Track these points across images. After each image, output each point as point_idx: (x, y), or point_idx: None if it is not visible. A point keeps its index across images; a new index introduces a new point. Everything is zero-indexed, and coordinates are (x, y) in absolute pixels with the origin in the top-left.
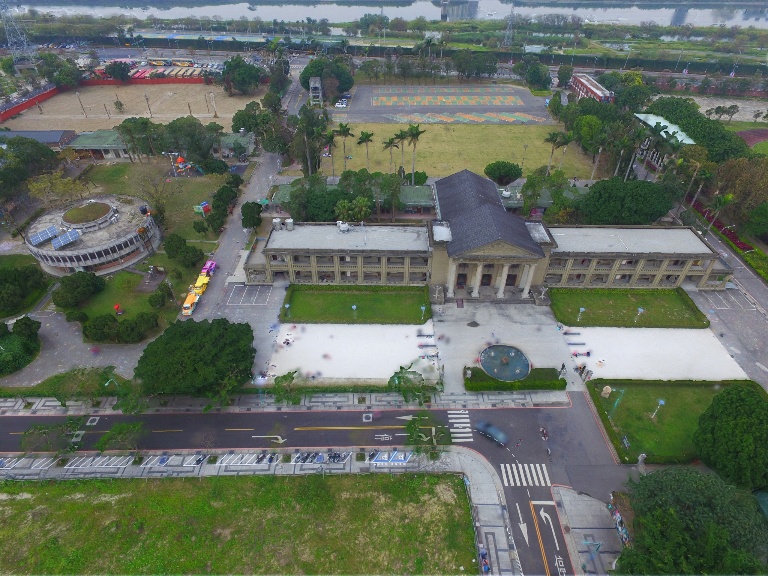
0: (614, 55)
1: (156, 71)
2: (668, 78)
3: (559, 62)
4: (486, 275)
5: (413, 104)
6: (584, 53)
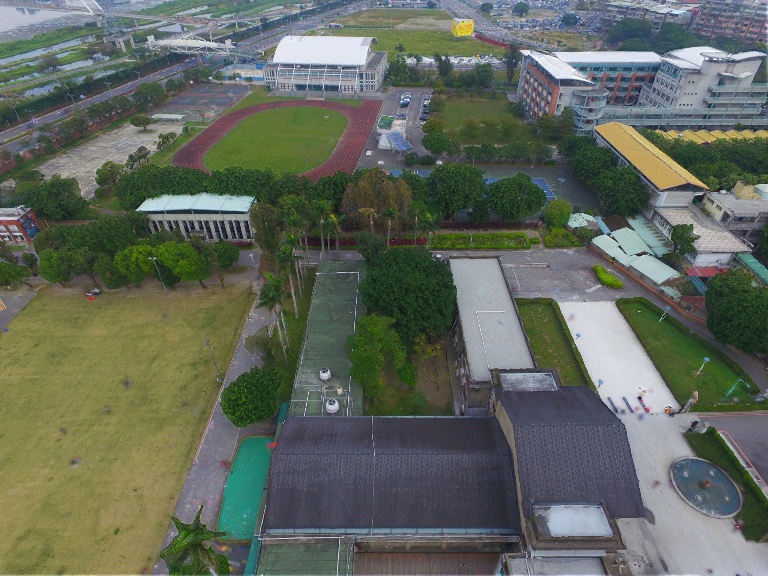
0: None
1: None
2: (1, 155)
3: None
4: None
5: None
6: None
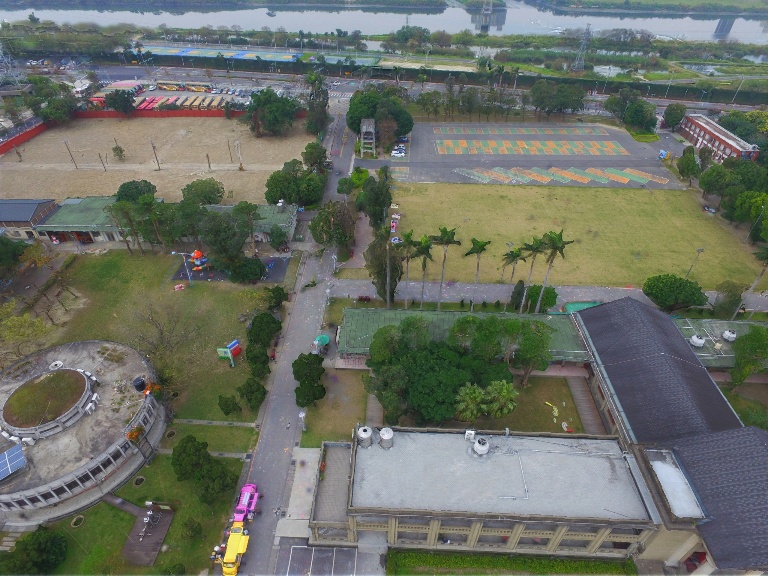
0: (714, 84)
1: (167, 100)
2: None
3: (650, 93)
4: None
5: (489, 153)
6: (669, 78)
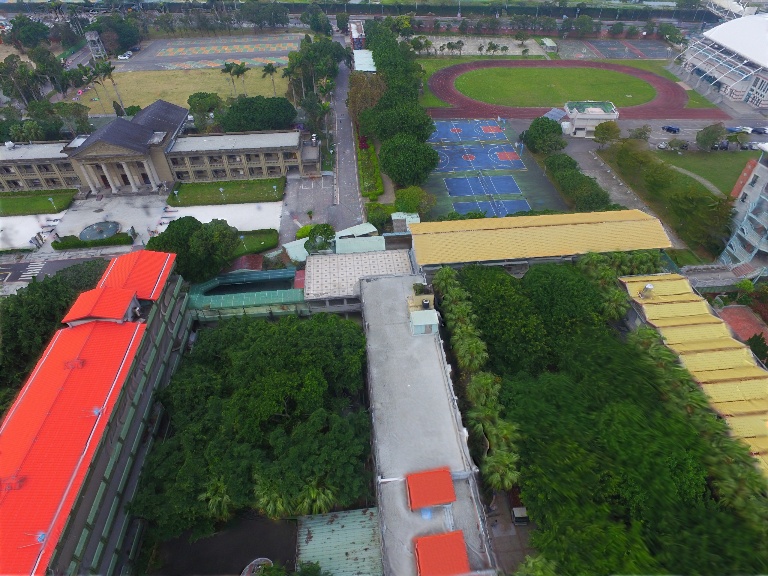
0: (413, 3)
1: None
2: (434, 21)
3: (359, 11)
4: (124, 175)
5: (194, 53)
6: None
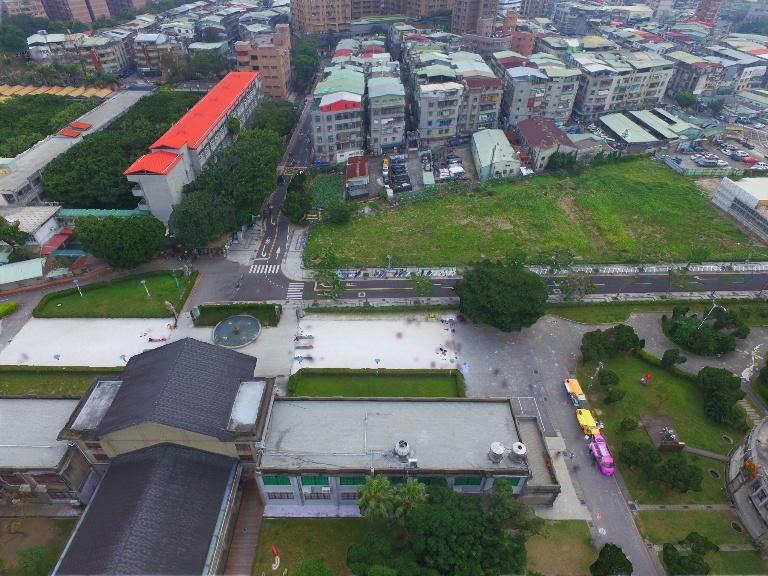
0: None
1: None
2: None
3: None
4: None
5: None
6: None
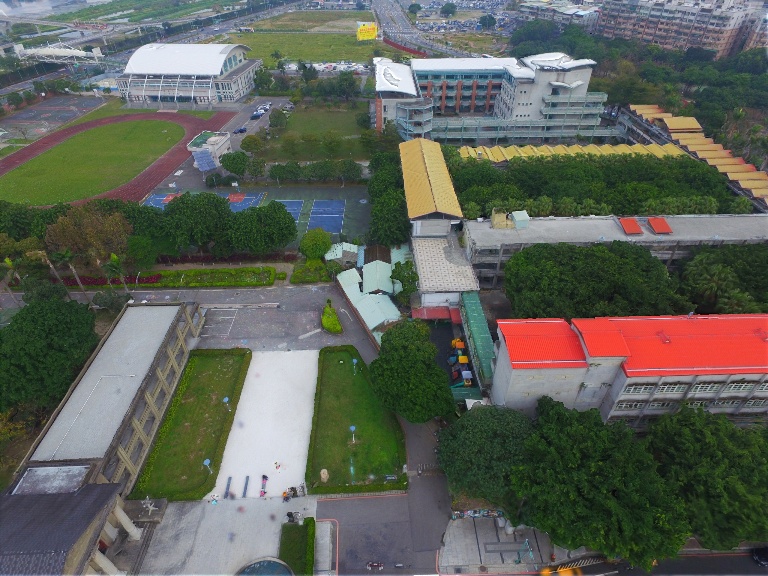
0: None
1: None
2: None
3: None
4: None
5: None
6: None
